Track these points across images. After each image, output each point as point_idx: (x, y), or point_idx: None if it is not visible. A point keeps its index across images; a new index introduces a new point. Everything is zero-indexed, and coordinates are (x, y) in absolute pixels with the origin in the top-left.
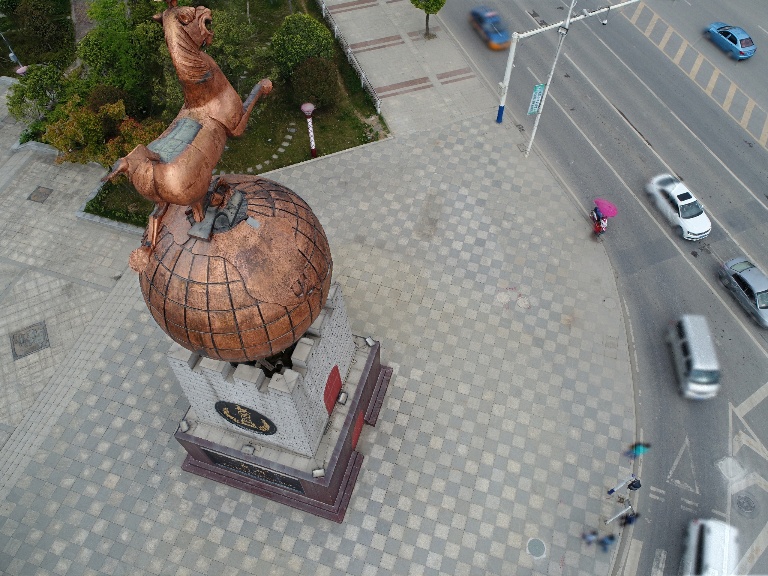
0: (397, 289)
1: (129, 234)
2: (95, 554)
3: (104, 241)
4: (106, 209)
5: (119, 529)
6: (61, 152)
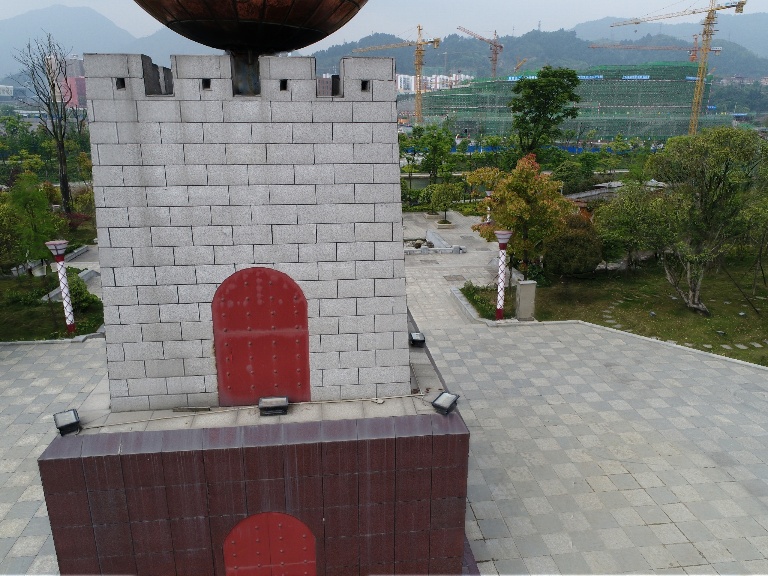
0: (702, 553)
1: (466, 317)
2: (25, 405)
3: (442, 311)
4: (475, 294)
5: (60, 410)
6: (483, 222)
